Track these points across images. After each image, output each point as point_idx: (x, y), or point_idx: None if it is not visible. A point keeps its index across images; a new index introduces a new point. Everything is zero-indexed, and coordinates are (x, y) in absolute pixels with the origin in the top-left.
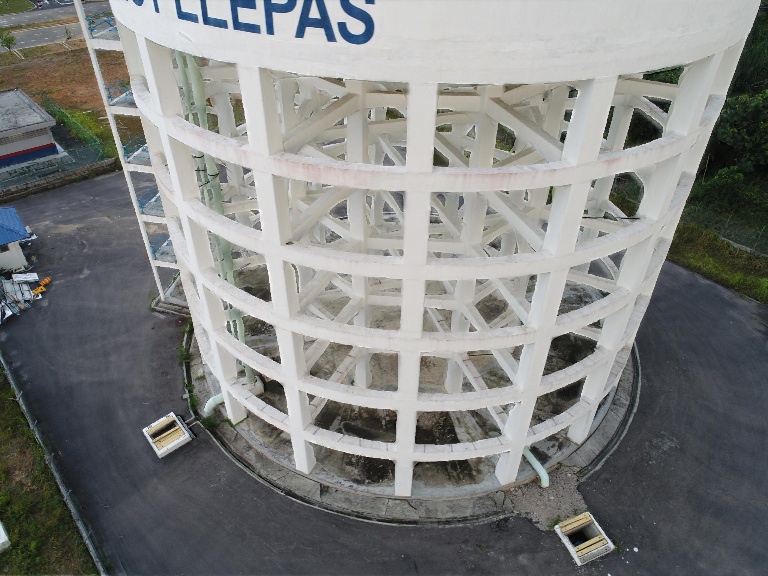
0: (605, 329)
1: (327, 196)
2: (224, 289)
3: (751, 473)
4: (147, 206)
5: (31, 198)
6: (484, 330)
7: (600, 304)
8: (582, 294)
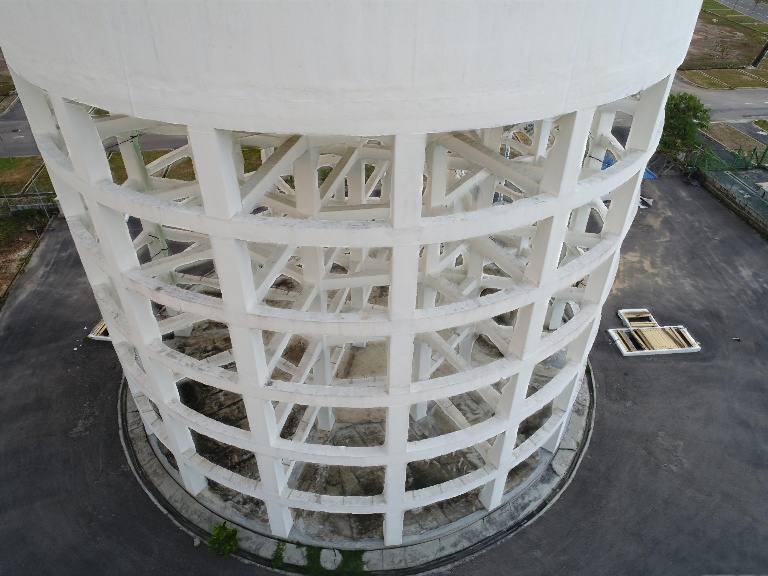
0: None
1: None
2: None
3: None
4: None
5: (726, 212)
6: (164, 159)
7: None
8: (259, 510)
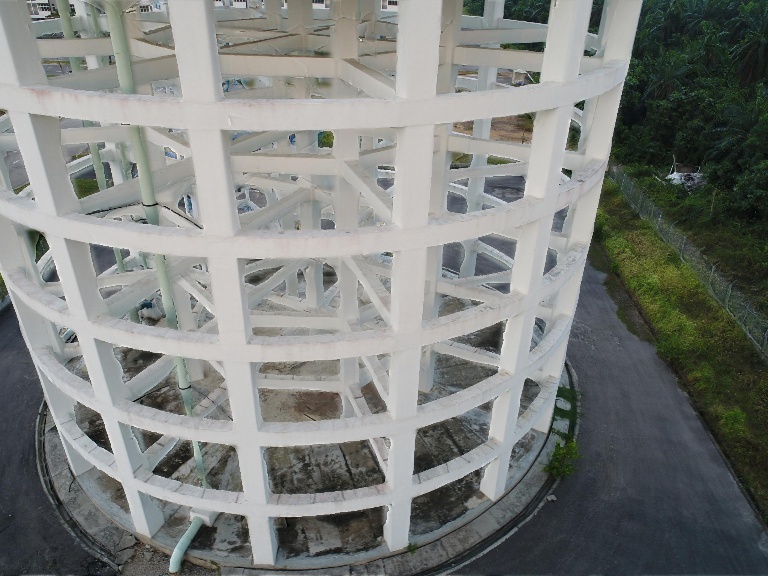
0: None
1: (78, 129)
2: None
3: None
4: None
5: None
6: None
7: (165, 332)
8: (522, 441)
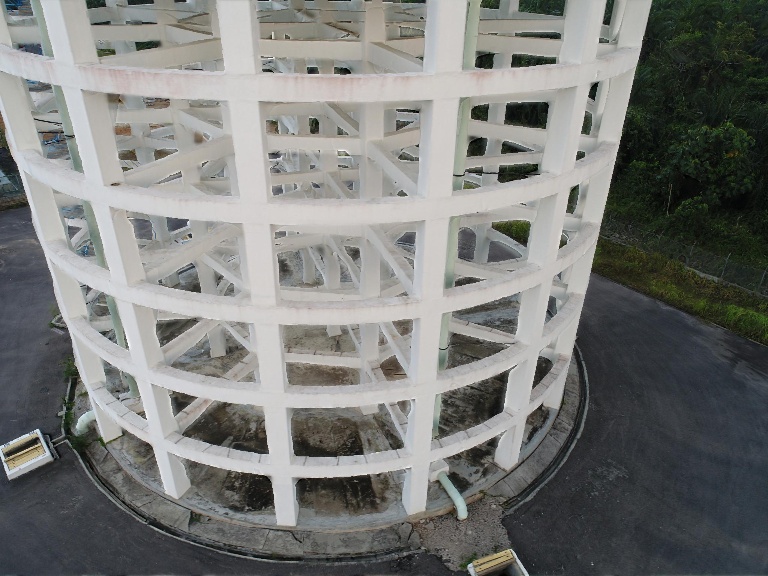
0: (521, 319)
1: (186, 151)
2: (65, 258)
3: (712, 508)
4: None
5: None
6: None
7: (503, 278)
8: None
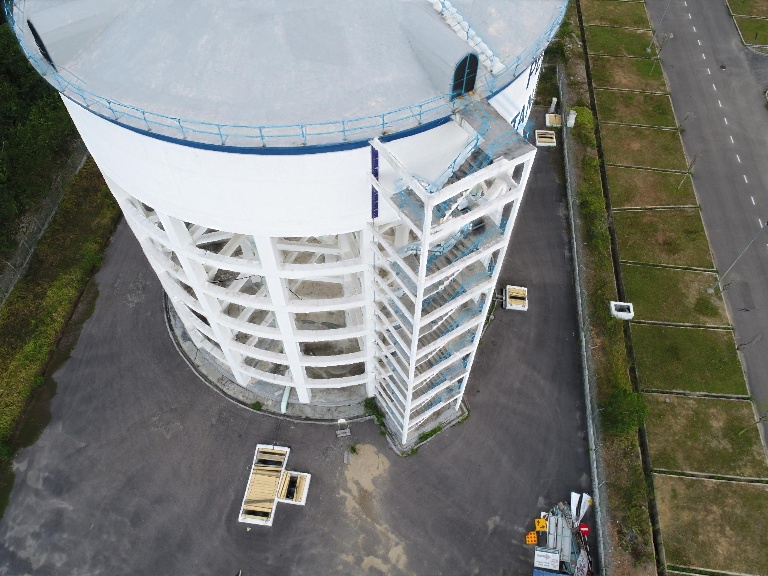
0: None
1: None
2: None
3: None
4: (456, 376)
5: None
6: None
7: None
8: None
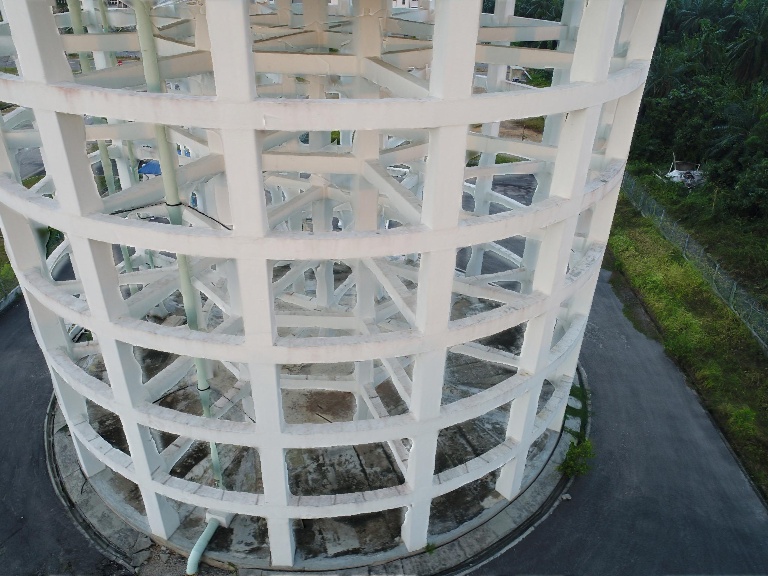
0: None
1: (90, 126)
2: None
3: None
4: None
5: None
6: None
7: (189, 334)
8: (535, 440)
